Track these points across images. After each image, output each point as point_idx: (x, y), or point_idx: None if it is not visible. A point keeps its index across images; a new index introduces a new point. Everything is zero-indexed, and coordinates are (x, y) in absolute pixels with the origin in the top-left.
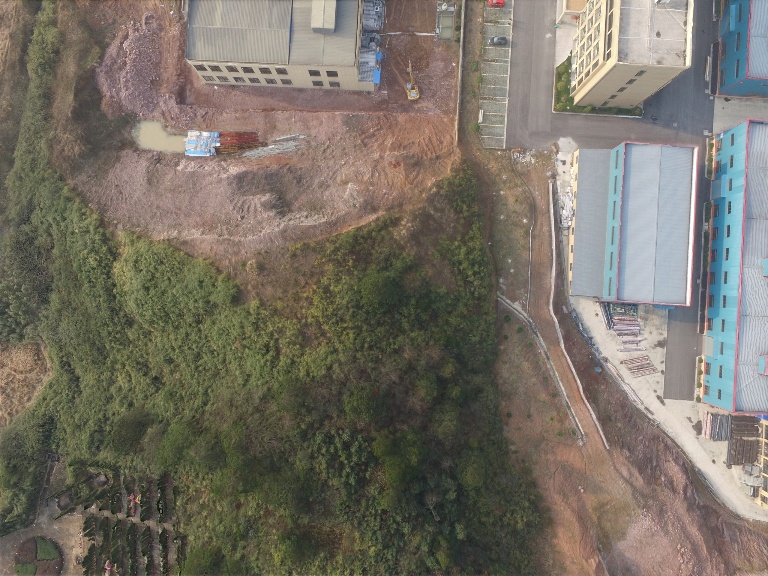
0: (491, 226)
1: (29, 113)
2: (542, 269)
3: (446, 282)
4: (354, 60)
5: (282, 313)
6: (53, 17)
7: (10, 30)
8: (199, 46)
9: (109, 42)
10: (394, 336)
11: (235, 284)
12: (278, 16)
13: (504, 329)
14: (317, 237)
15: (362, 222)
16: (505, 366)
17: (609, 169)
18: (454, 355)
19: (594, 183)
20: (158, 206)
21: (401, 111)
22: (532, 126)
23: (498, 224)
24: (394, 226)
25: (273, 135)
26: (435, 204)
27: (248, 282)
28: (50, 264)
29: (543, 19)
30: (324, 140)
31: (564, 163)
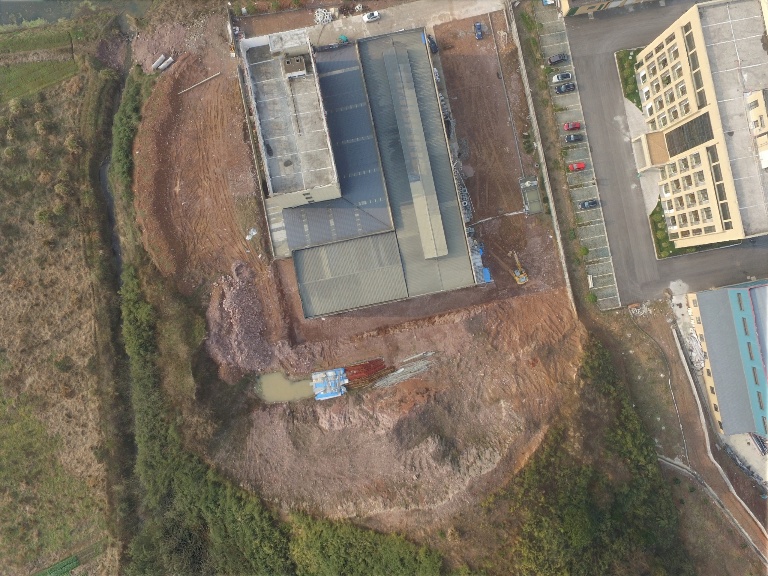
0: (630, 388)
1: (141, 396)
2: (691, 418)
3: (622, 475)
4: (472, 277)
5: (493, 571)
6: (140, 292)
7: (92, 310)
8: (314, 302)
9: (206, 305)
10: (599, 554)
11: (439, 555)
12: (386, 252)
13: (676, 491)
14: (502, 482)
15: (533, 445)
16: (690, 531)
17: (730, 307)
18: (655, 550)
19: (719, 324)
20: (316, 473)
21: (512, 295)
22: (641, 278)
23: (637, 385)
24: (564, 440)
25: (398, 357)
26: (587, 397)
27: (450, 549)
28: (209, 548)
29: (624, 171)
30: (454, 353)
31: (680, 306)
